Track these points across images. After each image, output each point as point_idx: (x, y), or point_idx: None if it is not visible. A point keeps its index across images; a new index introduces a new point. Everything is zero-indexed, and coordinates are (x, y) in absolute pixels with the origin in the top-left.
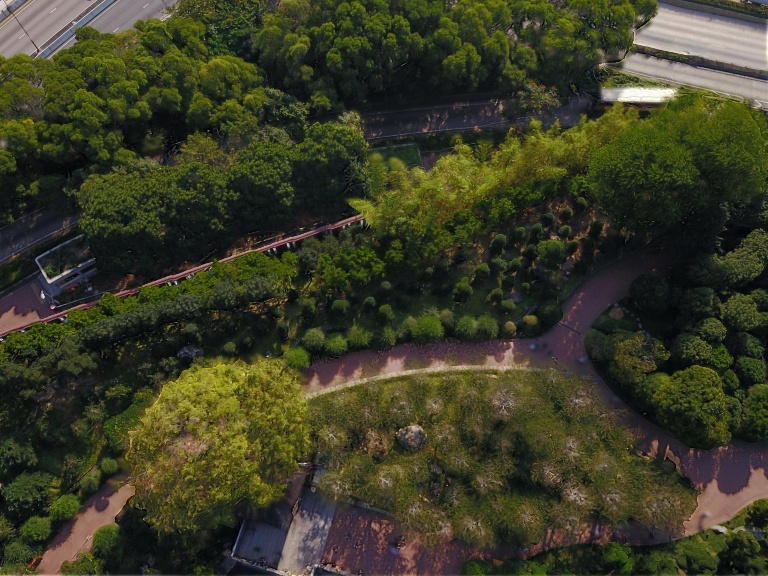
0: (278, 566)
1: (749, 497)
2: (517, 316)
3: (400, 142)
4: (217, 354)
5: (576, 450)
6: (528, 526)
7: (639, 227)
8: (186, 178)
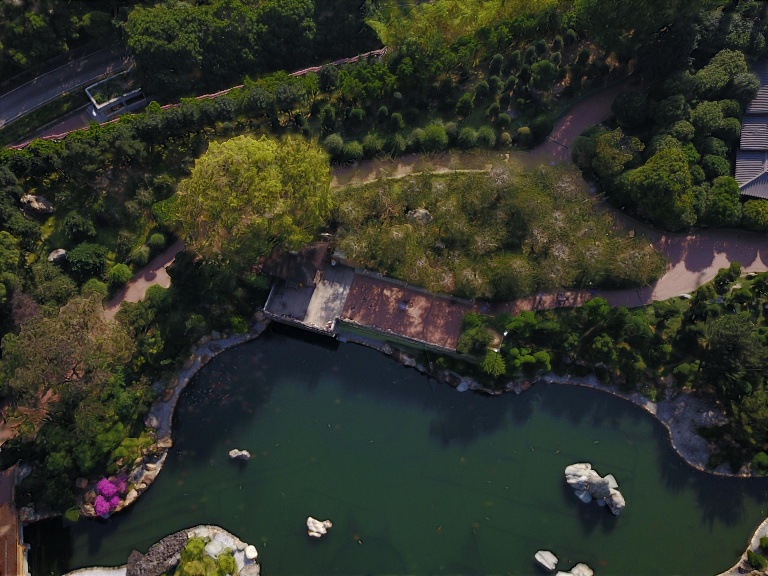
0: (303, 321)
1: (712, 274)
2: (512, 131)
3: None
4: None
5: (561, 223)
6: (518, 273)
7: (622, 55)
8: (221, 9)
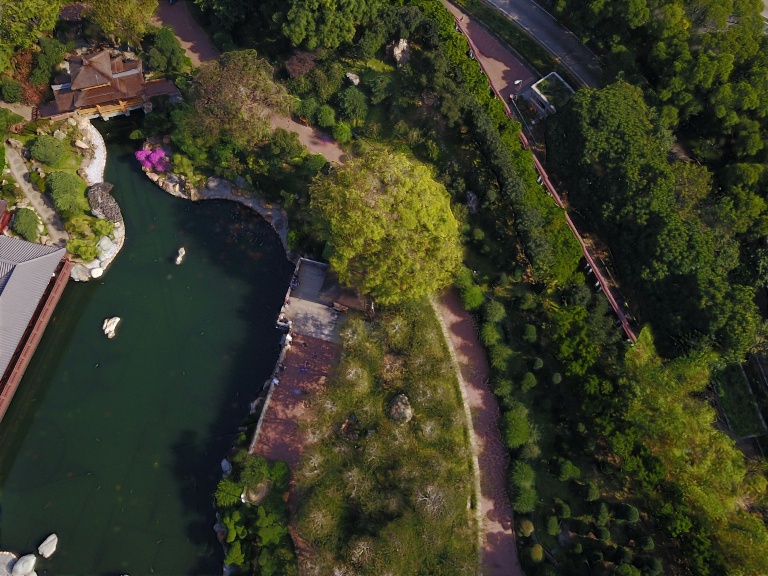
0: (293, 297)
1: None
2: (542, 539)
3: (767, 415)
4: (472, 224)
5: None
6: (311, 520)
7: None
8: (652, 170)
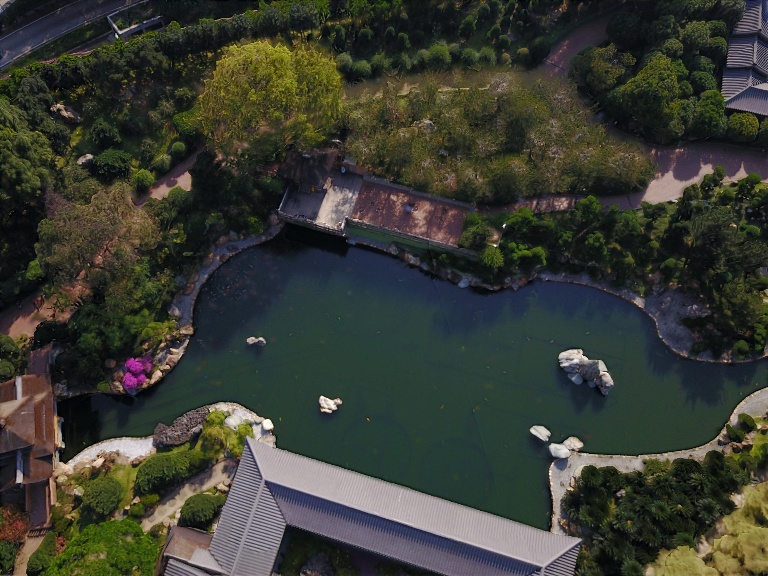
0: None
1: (698, 182)
2: (512, 53)
3: None
4: None
5: (557, 130)
6: (517, 173)
7: None
8: None
